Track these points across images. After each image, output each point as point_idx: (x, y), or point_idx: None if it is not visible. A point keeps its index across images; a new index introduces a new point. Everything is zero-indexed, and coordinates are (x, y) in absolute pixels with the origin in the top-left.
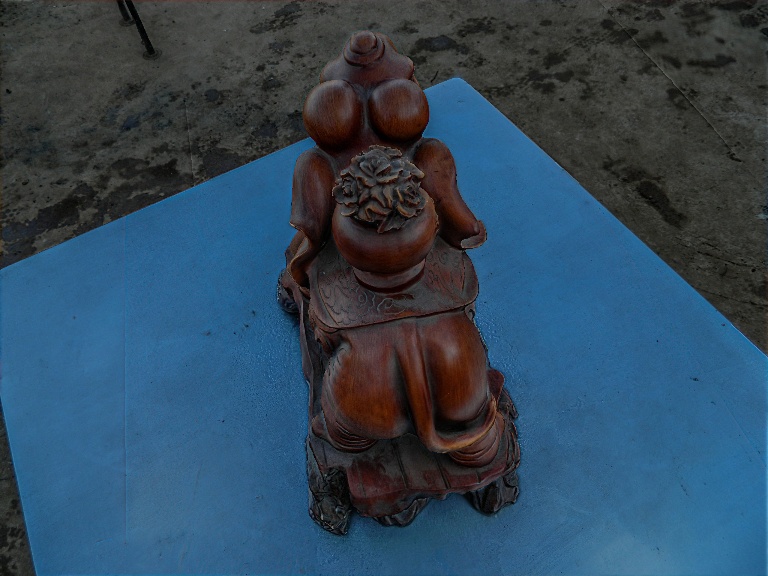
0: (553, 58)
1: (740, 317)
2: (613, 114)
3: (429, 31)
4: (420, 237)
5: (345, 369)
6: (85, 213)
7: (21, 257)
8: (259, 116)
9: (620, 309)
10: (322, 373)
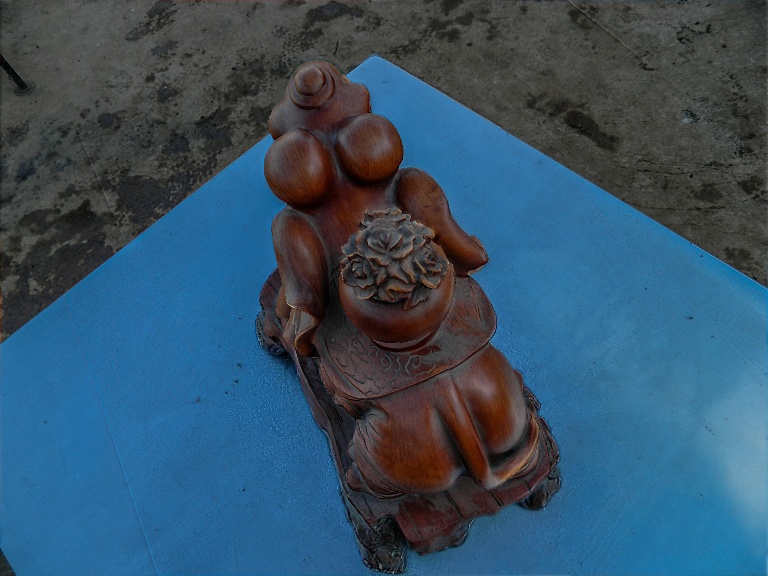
0: (449, 2)
1: (690, 225)
2: (523, 49)
3: None
4: (444, 297)
5: (386, 439)
6: (6, 283)
7: None
8: (164, 132)
9: (602, 265)
10: (339, 421)
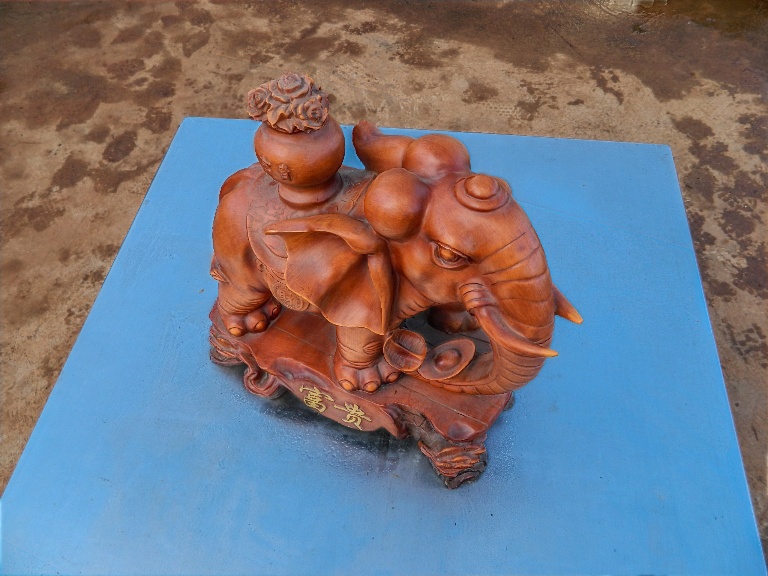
0: None
1: None
2: None
3: None
4: None
5: None
6: None
7: None
8: None
9: None
10: None
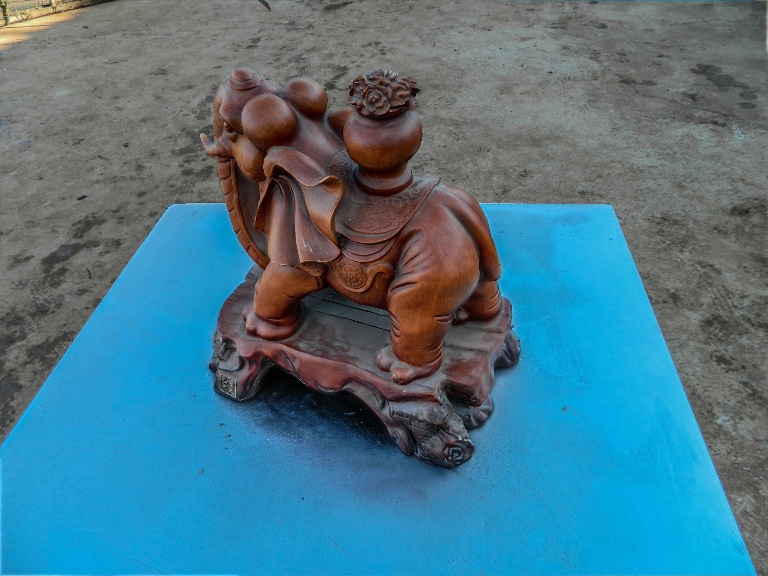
0: None
1: None
2: None
3: (45, 250)
4: None
5: (429, 248)
6: None
7: None
8: None
9: None
10: (356, 360)
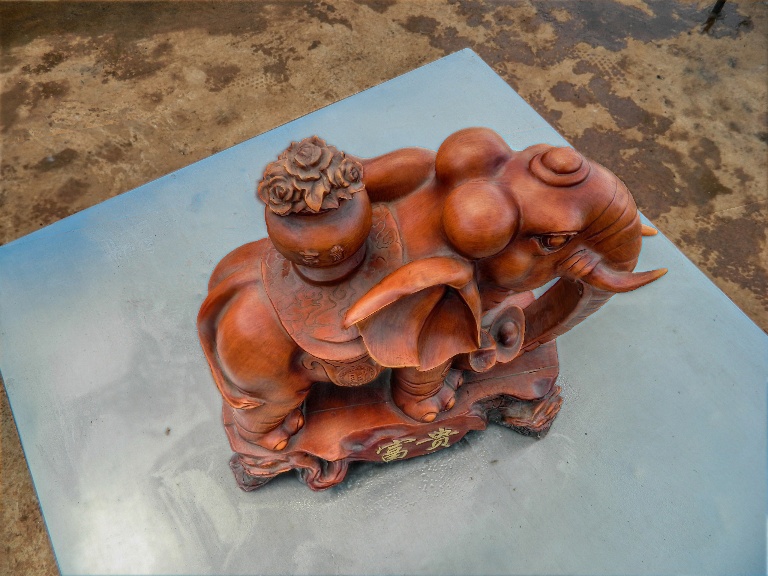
0: None
1: None
2: None
3: None
4: (278, 233)
5: None
6: (635, 132)
7: (573, 100)
8: None
9: None
10: None
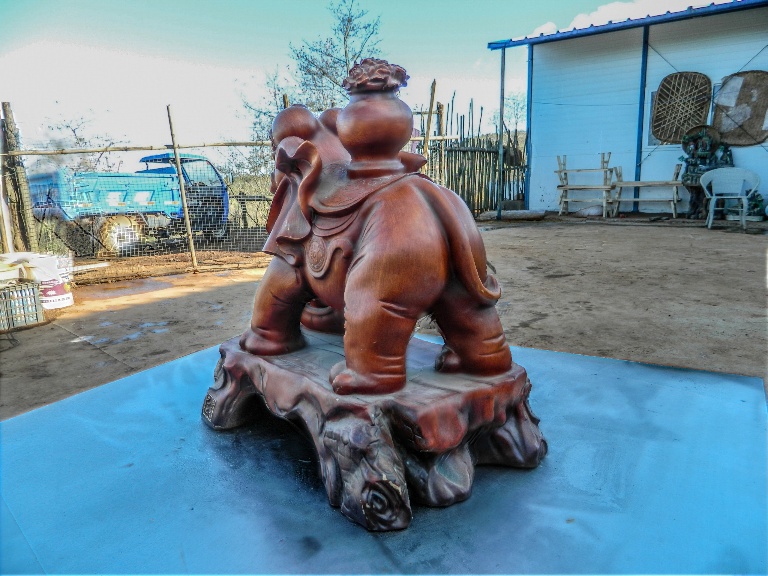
0: None
1: None
2: None
3: None
4: None
5: (382, 216)
6: None
7: None
8: None
9: None
10: (315, 376)
